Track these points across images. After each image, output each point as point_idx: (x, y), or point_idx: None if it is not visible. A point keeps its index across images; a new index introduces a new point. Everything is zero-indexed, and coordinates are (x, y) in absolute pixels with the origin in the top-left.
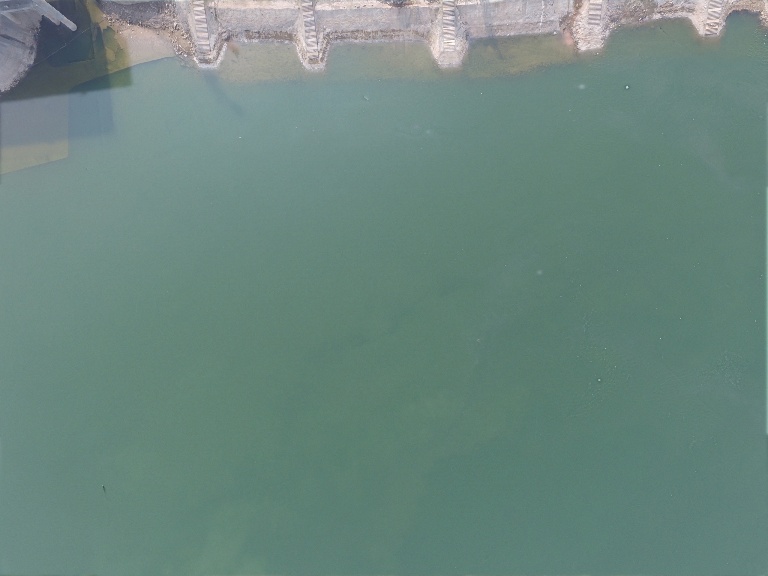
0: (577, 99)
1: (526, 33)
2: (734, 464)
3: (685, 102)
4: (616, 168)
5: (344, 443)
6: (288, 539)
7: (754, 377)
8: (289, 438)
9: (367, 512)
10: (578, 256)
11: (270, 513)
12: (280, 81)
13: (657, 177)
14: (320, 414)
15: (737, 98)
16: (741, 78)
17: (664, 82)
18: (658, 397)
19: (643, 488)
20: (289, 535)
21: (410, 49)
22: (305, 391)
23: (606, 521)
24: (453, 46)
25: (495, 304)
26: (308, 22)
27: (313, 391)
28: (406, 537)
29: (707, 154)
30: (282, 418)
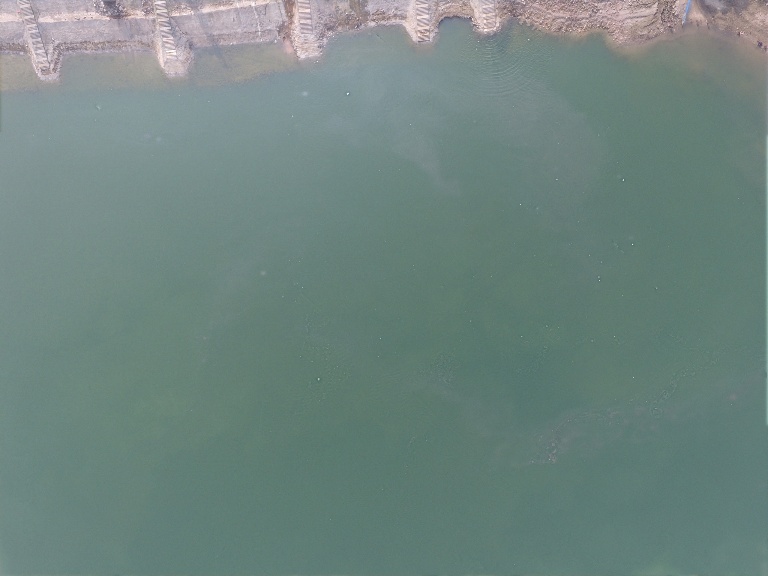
0: (297, 106)
1: (248, 42)
2: (452, 459)
3: (403, 108)
4: (334, 173)
5: (86, 441)
6: (34, 532)
7: (467, 375)
8: (32, 436)
9: (107, 506)
10: (300, 259)
11: (16, 508)
12: (18, 92)
13: (375, 182)
14: (64, 413)
15: (450, 103)
16: (456, 84)
17: (377, 89)
18: (377, 395)
19: (357, 483)
20: (35, 528)
21: (139, 59)
22: (49, 391)
23: (325, 514)
24: (175, 56)
25: (223, 306)
26: (33, 34)
27: (57, 391)
28: (144, 530)
29: (423, 159)
30: (25, 417)
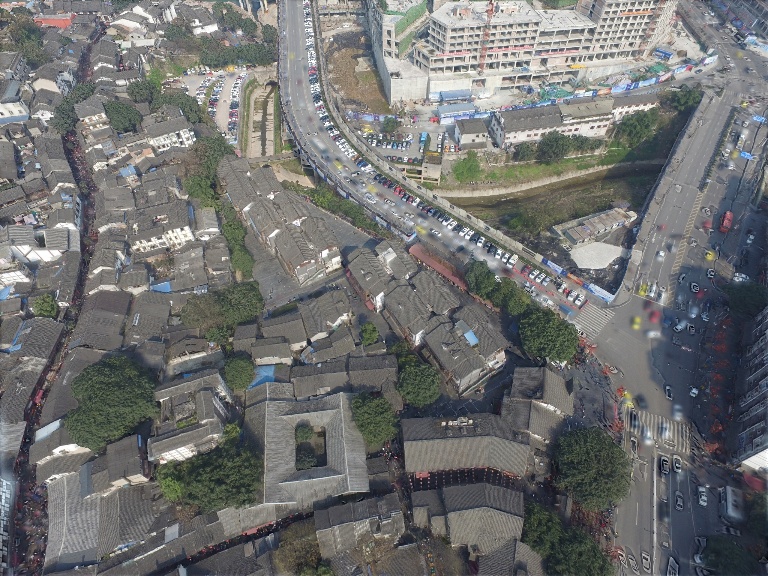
0: None
1: None
2: None
3: None
4: None
5: None
6: None
7: None
8: None
9: None
10: None
11: None
12: None
13: None
14: None
15: None
16: None
17: None
18: None
19: None
20: None
21: None
22: None
23: None
24: None
25: None
26: None
27: None
28: None
29: None
30: None
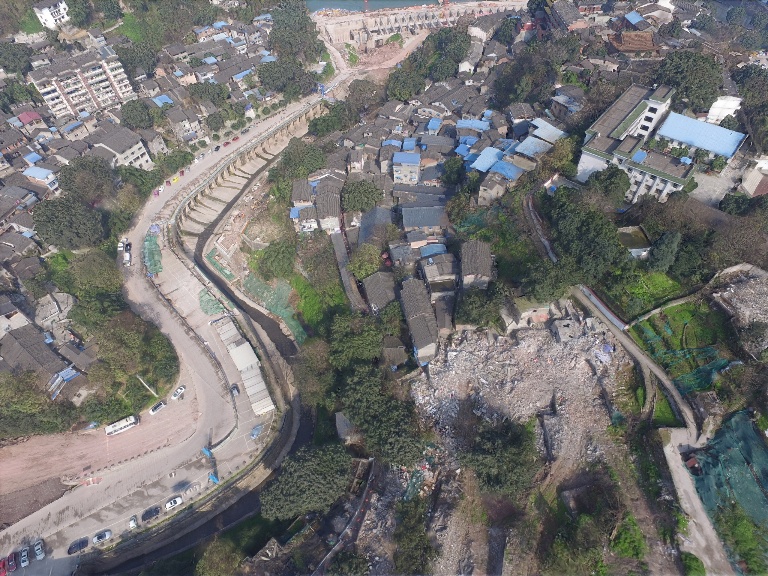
0: None
1: None
2: None
3: (394, 3)
4: None
5: None
6: None
7: None
8: None
9: None
10: None
11: None
12: None
13: None
14: None
15: None
16: None
17: (404, 1)
18: None
19: None
20: None
21: None
22: None
23: None
24: None
25: None
26: None
27: None
28: None
29: None
30: None
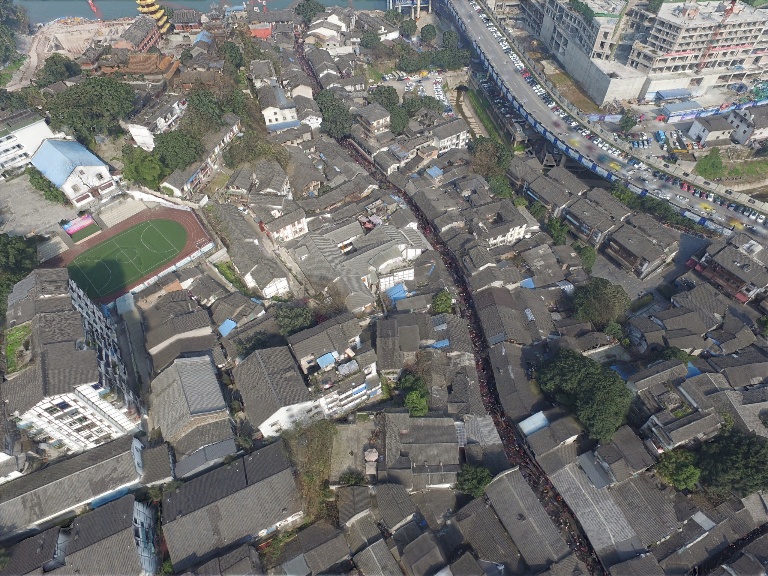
0: None
1: None
2: None
3: None
4: (191, 0)
5: None
6: None
7: None
8: None
9: None
10: None
11: None
12: None
13: (178, 0)
14: None
15: None
16: None
17: None
18: None
19: None
20: None
21: None
22: None
23: None
24: None
25: None
26: None
27: None
28: None
29: None
30: None
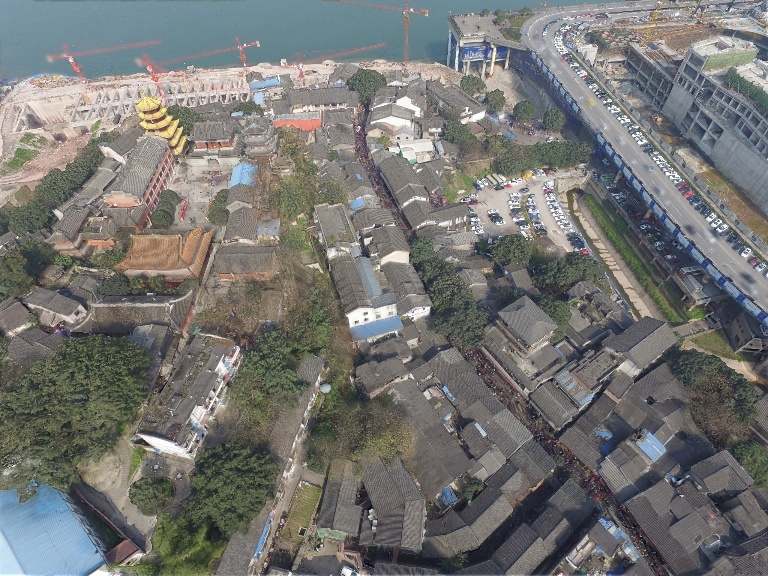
0: None
1: None
2: None
3: None
4: (198, 44)
5: None
6: None
7: None
8: None
9: None
10: None
11: None
12: None
13: (182, 44)
14: None
15: (137, 61)
16: (132, 66)
17: (168, 60)
18: None
19: None
20: None
21: None
22: None
23: None
24: None
25: (259, 18)
26: None
27: (335, 4)
28: None
29: None
30: None
